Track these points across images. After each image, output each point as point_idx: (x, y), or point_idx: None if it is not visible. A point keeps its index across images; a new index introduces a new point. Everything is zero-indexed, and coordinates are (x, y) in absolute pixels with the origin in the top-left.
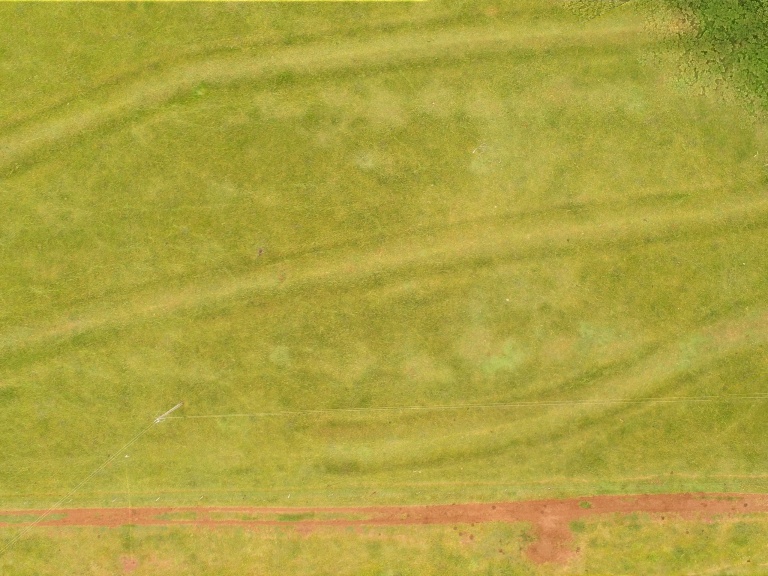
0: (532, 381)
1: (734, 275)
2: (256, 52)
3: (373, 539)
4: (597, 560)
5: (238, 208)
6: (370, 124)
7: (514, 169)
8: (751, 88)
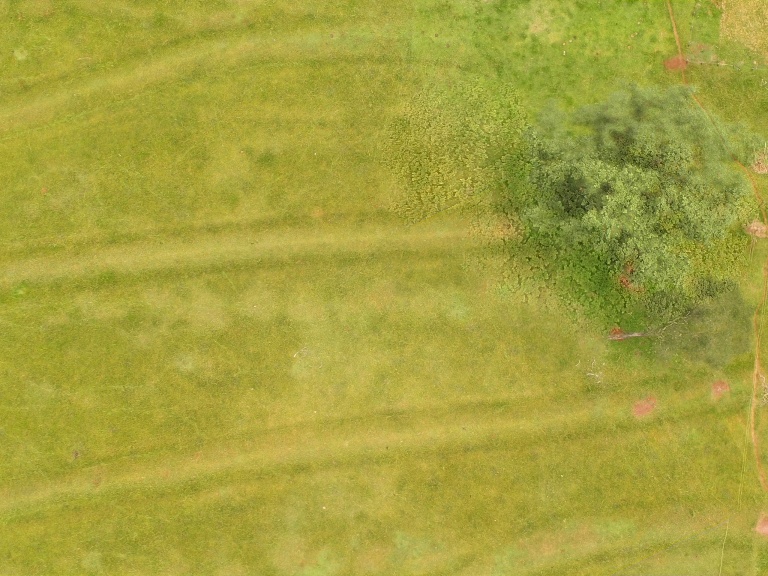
0: None
1: (552, 487)
2: (79, 251)
3: None
4: None
5: (56, 409)
6: (191, 326)
7: (335, 374)
8: (574, 296)
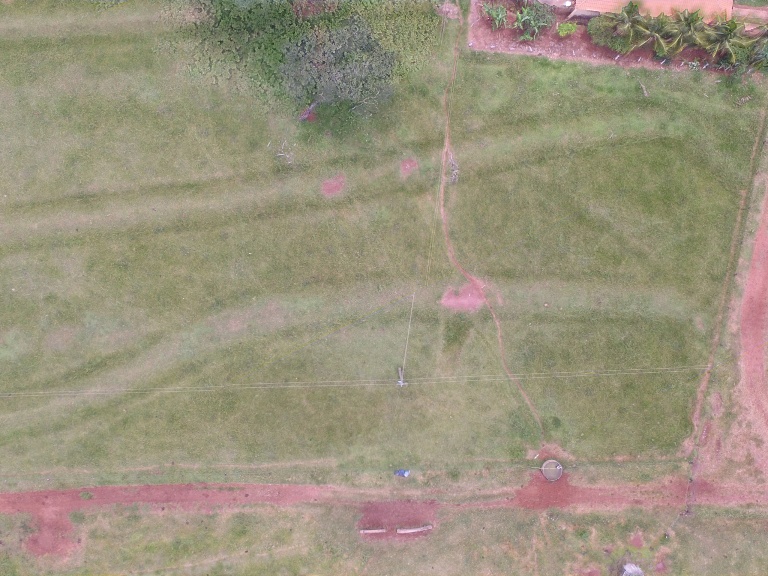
0: (35, 371)
1: (241, 265)
2: None
3: None
4: (95, 551)
5: None
6: None
7: (25, 158)
8: (264, 78)
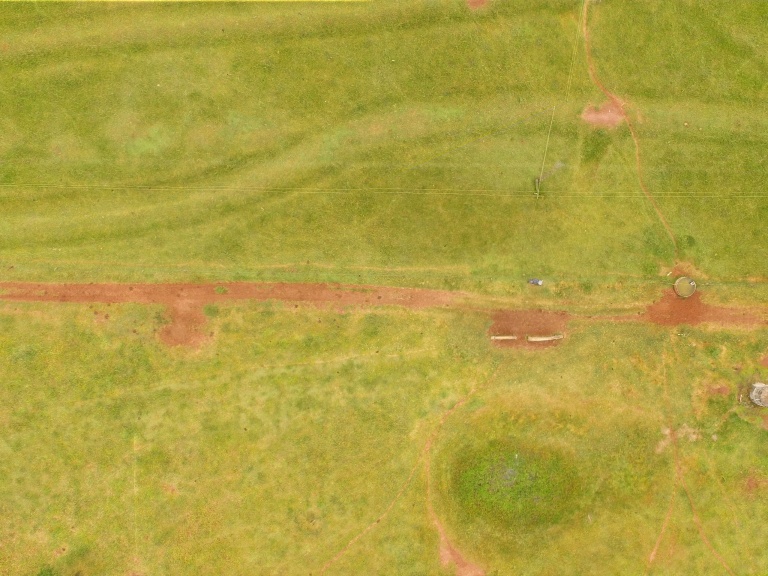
0: (176, 165)
1: (384, 72)
2: None
3: (8, 313)
4: (228, 344)
5: None
6: None
7: None
8: None
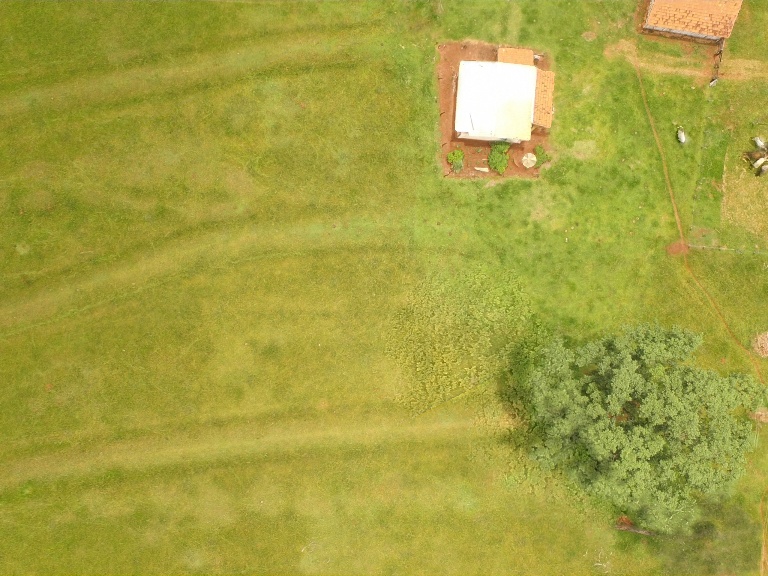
0: None
1: None
2: (85, 448)
3: None
4: None
5: None
6: (198, 524)
7: (343, 569)
8: (580, 487)
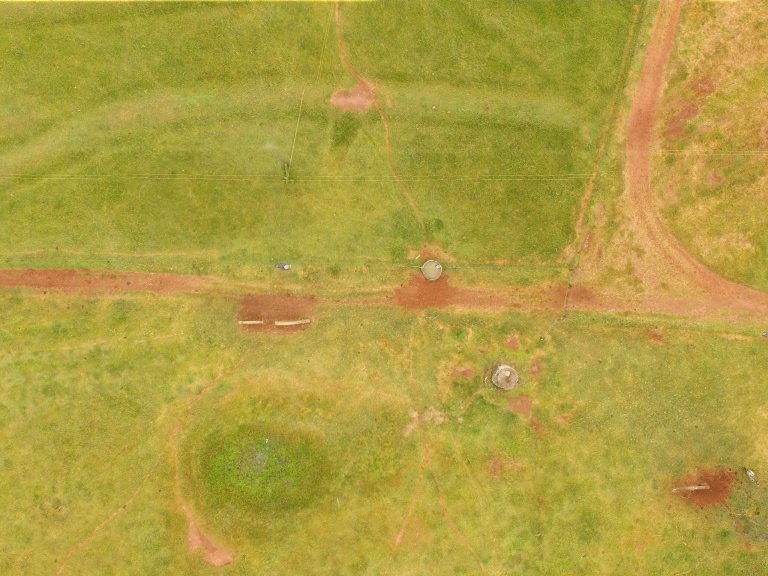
0: None
1: (134, 57)
2: None
3: None
4: None
5: None
6: None
7: None
8: None
